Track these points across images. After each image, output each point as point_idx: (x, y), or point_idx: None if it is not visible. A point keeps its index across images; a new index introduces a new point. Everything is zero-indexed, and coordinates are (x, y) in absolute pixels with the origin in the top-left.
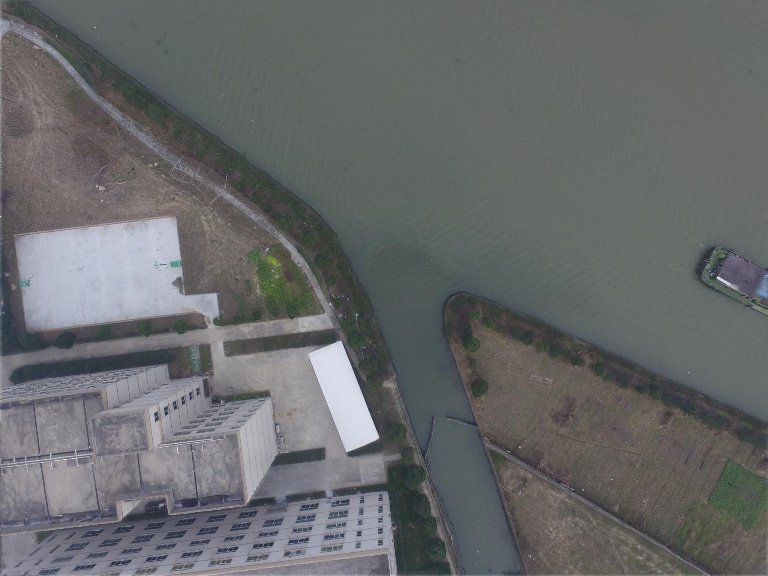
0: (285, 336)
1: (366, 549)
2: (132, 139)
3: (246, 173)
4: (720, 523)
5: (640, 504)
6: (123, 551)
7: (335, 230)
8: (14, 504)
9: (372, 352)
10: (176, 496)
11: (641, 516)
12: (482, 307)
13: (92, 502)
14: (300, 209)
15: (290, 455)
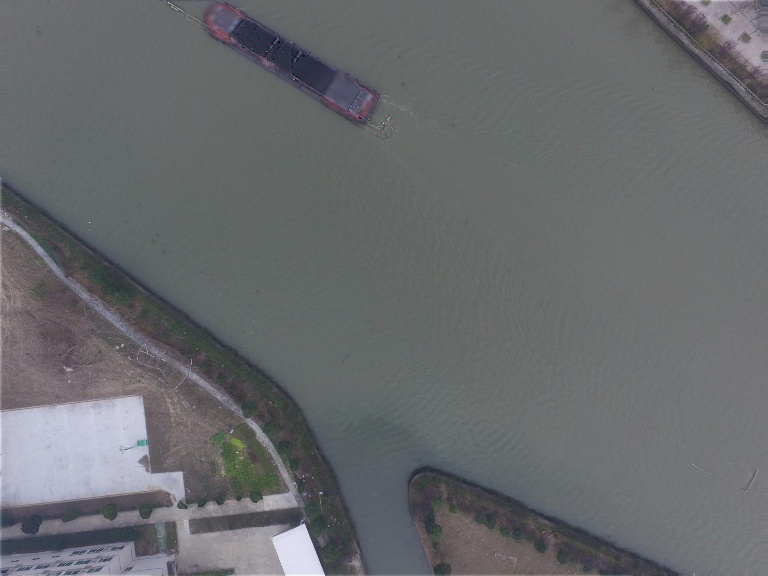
0: (250, 515)
1: None
2: (100, 319)
3: (212, 353)
4: None
5: None
6: None
7: (301, 405)
8: None
9: (336, 530)
10: None
11: None
12: (446, 487)
13: None
14: (265, 389)
15: None
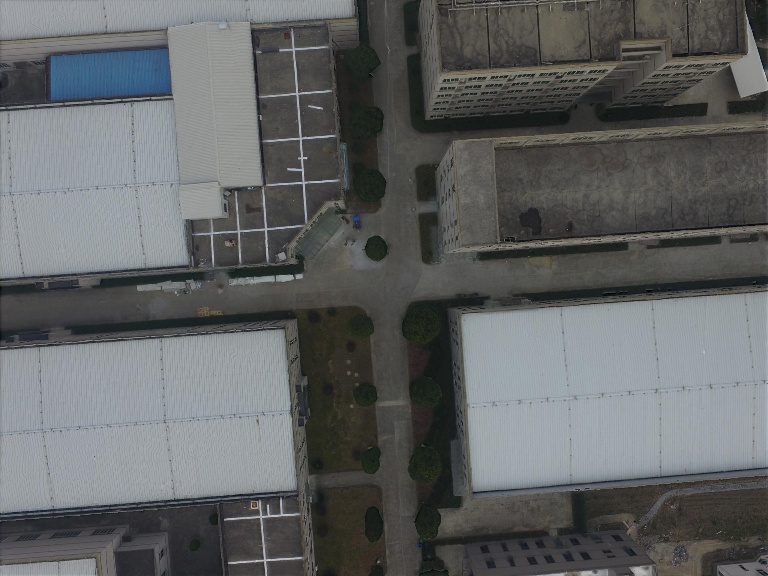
0: None
1: None
2: None
3: None
4: None
5: None
6: None
7: None
8: (507, 47)
9: None
10: None
11: None
12: None
13: (585, 50)
14: None
15: (675, 107)
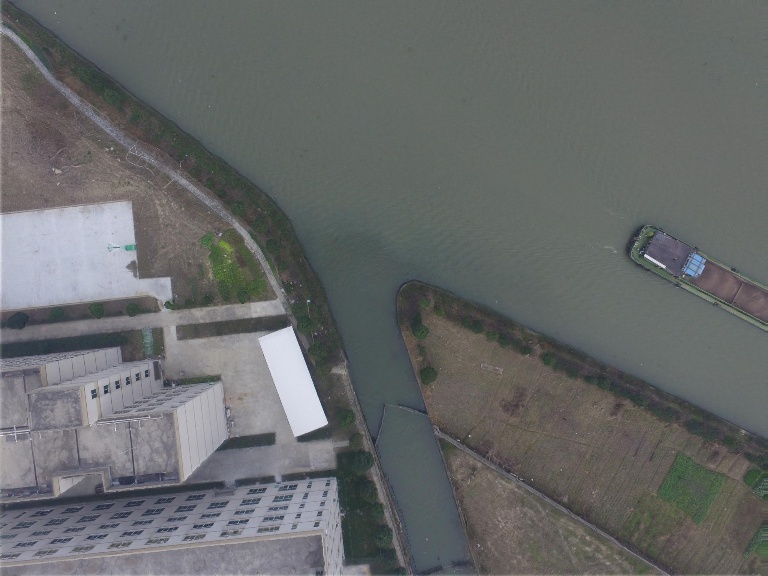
0: (237, 321)
1: (301, 530)
2: (89, 123)
3: (201, 159)
4: (669, 516)
5: (589, 495)
6: (67, 530)
7: (290, 217)
8: None
9: (323, 338)
10: (113, 474)
11: (590, 507)
12: (433, 295)
13: (30, 478)
14: (254, 195)
15: (240, 439)
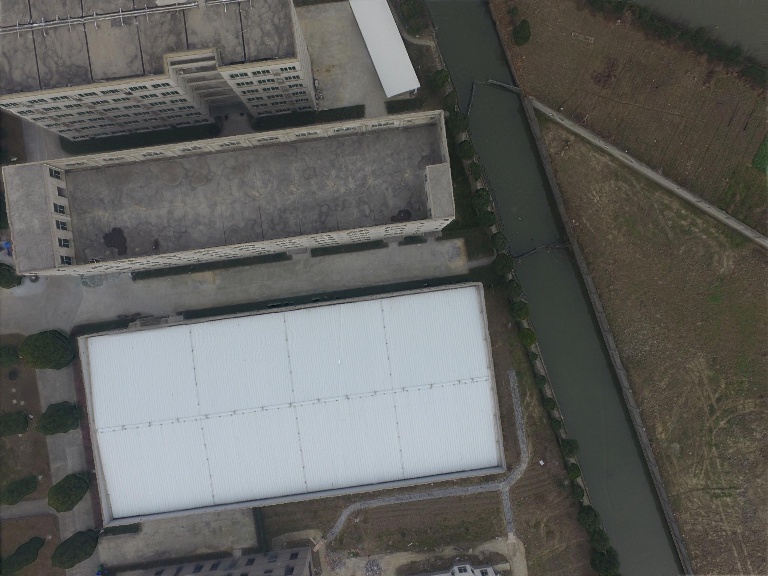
0: None
1: None
2: None
3: None
4: (765, 186)
5: (684, 167)
6: None
7: None
8: (56, 68)
9: None
10: (223, 59)
11: (685, 179)
12: None
13: (137, 65)
14: None
15: (329, 111)
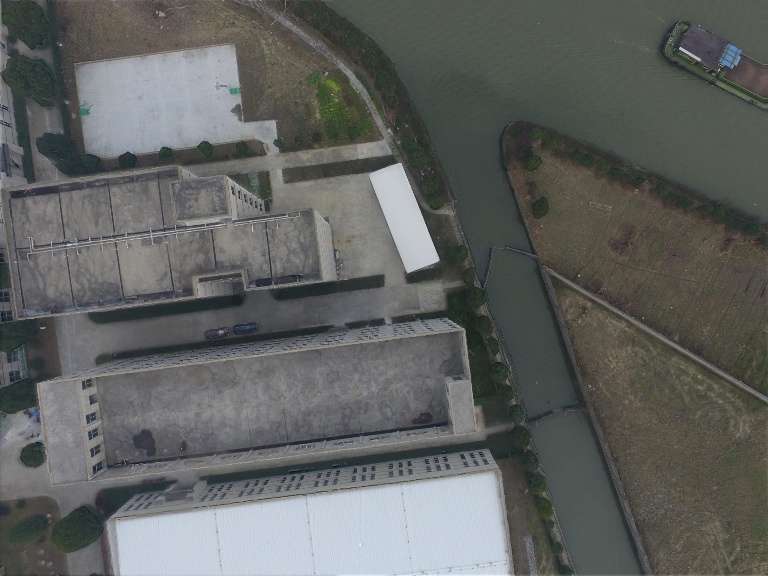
0: (344, 162)
1: (441, 330)
2: None
3: None
4: None
5: (700, 333)
6: None
7: (392, 61)
8: (89, 285)
9: None
10: (250, 276)
11: (701, 345)
12: (541, 133)
13: (167, 282)
14: (358, 35)
15: (349, 281)
